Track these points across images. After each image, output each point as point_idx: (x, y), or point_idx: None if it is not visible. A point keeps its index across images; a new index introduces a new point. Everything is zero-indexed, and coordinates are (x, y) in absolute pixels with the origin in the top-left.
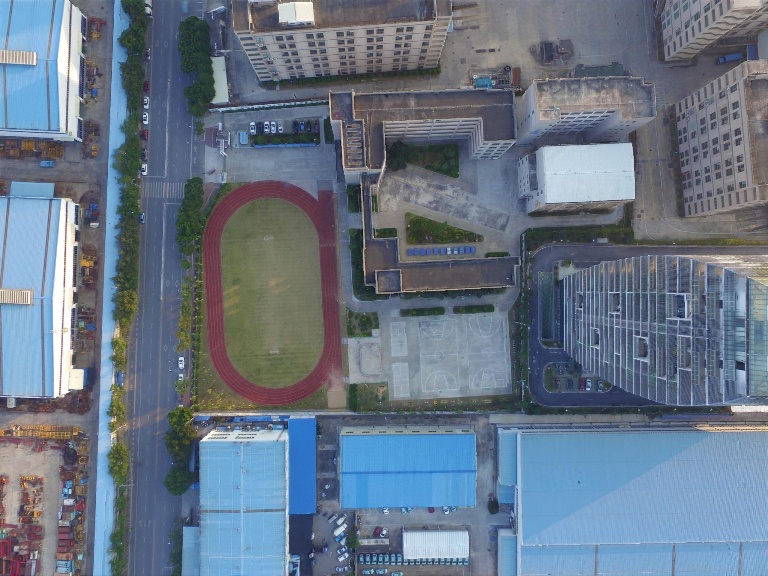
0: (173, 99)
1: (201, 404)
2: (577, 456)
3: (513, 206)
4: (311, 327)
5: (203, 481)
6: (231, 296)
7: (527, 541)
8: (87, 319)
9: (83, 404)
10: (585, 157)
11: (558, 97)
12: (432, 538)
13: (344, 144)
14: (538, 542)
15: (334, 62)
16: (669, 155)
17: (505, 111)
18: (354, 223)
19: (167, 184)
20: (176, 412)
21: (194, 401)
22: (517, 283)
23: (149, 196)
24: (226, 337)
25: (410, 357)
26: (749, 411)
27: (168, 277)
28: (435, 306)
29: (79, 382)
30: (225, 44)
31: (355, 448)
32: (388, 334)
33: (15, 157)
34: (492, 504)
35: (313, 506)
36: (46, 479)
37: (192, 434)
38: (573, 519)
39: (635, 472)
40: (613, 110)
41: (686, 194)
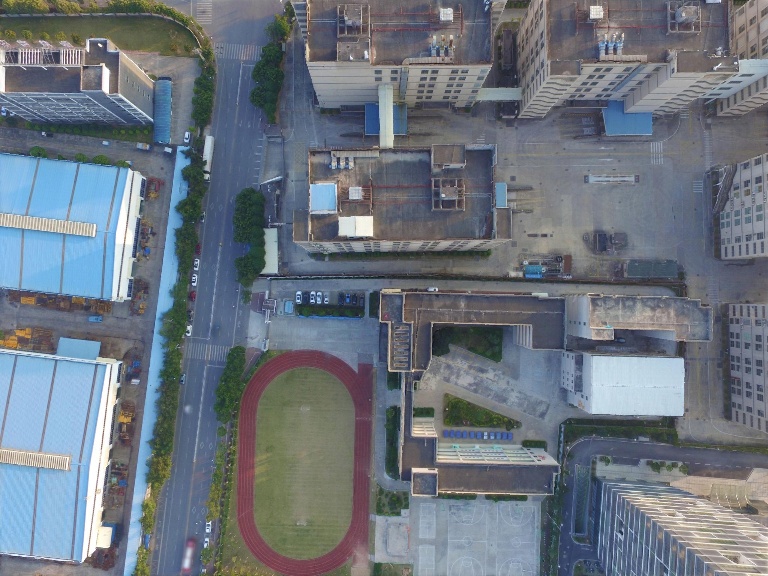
0: (223, 262)
1: (224, 570)
2: None
3: (554, 394)
4: (340, 500)
5: None
6: (263, 463)
7: None
8: (120, 475)
9: (108, 560)
10: (634, 370)
11: (612, 313)
12: None
13: (391, 345)
14: None
15: (386, 248)
16: (719, 354)
17: (556, 319)
18: (392, 399)
19: None
20: None
21: (218, 567)
22: None
23: (191, 357)
24: (255, 504)
25: (438, 540)
26: None
27: (203, 439)
28: None
29: (107, 540)
30: (278, 212)
31: None
32: (417, 515)
33: (65, 309)
34: None
35: None
36: None
37: None
38: None
39: None
40: (667, 330)
41: (734, 399)
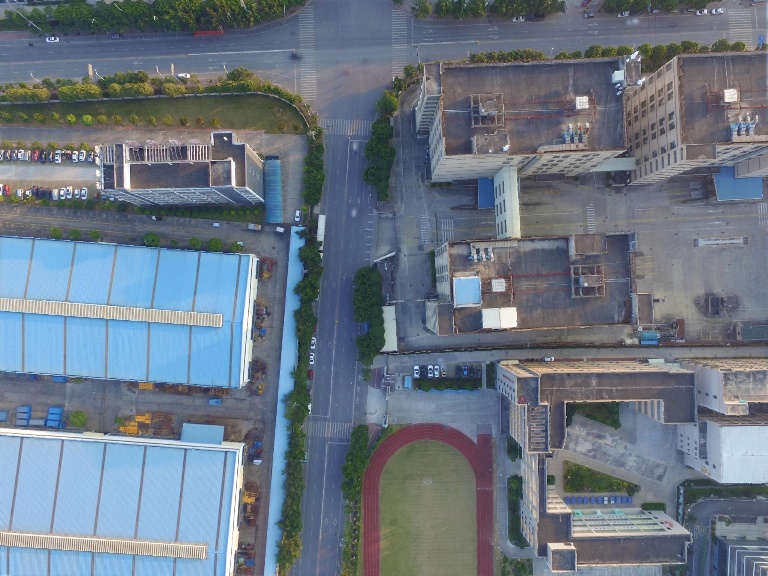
0: (339, 339)
1: None
2: None
3: (671, 457)
4: (465, 570)
5: None
6: (388, 536)
7: None
8: (247, 555)
9: None
10: (762, 439)
11: (743, 386)
12: None
13: (528, 427)
14: None
15: None
16: None
17: (685, 393)
18: (512, 468)
19: (330, 423)
20: None
21: None
22: None
23: (312, 435)
24: None
25: None
26: None
27: (327, 516)
28: None
29: None
30: (393, 288)
31: None
32: None
33: (184, 393)
34: None
35: None
36: None
37: None
38: None
39: None
40: None
41: None
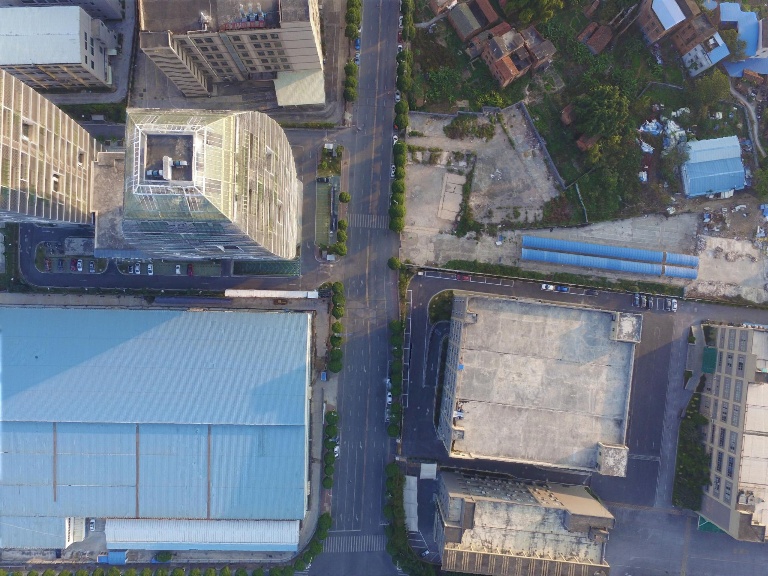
0: None
1: None
2: (38, 331)
3: None
4: None
5: None
6: None
7: None
8: None
9: None
10: (28, 19)
11: None
12: None
13: None
14: None
15: None
16: None
17: None
18: None
19: None
20: None
21: None
22: None
23: None
24: None
25: None
26: (244, 296)
27: None
28: None
29: None
30: None
31: None
32: None
33: None
34: None
35: None
36: None
37: None
38: (26, 394)
39: (97, 349)
40: None
41: None
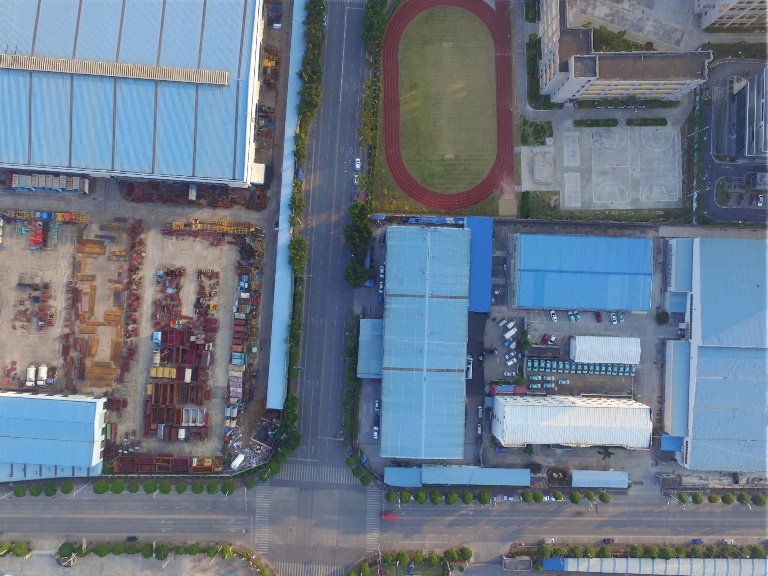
0: None
1: None
2: (756, 261)
3: (688, 22)
4: (485, 135)
5: (389, 265)
6: (407, 101)
7: (706, 341)
8: (267, 118)
9: (261, 201)
10: None
11: None
12: (604, 342)
13: None
14: (717, 342)
15: None
16: None
17: None
18: (530, 33)
19: None
20: (359, 203)
21: (369, 202)
22: (690, 98)
23: None
24: (401, 141)
25: (582, 167)
26: None
27: (347, 80)
28: (608, 118)
29: (260, 176)
30: None
31: (533, 247)
32: (561, 144)
33: None
34: (662, 314)
35: (488, 305)
36: (222, 273)
37: (371, 228)
38: (752, 321)
39: None
40: None
41: None
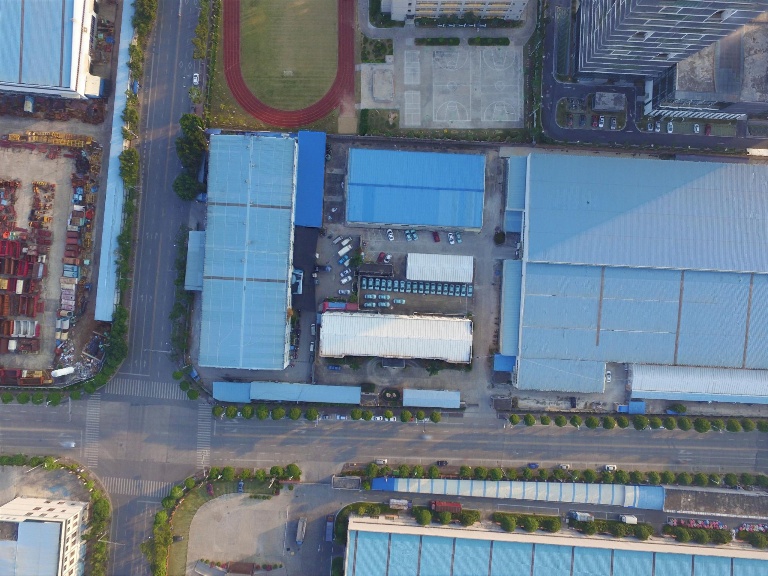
0: None
1: (213, 121)
2: (587, 177)
3: None
4: (325, 52)
5: (212, 174)
6: (248, 17)
7: (533, 256)
8: (106, 31)
9: (98, 114)
10: None
11: None
12: (436, 260)
13: None
14: (544, 258)
15: None
16: None
17: None
18: None
19: None
20: (188, 114)
21: (206, 117)
22: (534, 18)
23: None
24: (241, 57)
25: (423, 86)
26: (765, 155)
27: None
28: (450, 37)
29: (95, 88)
30: None
31: (364, 161)
32: (402, 62)
33: None
34: (498, 233)
35: (319, 220)
36: (58, 186)
37: (203, 141)
38: (580, 238)
39: (646, 197)
40: None
41: None
